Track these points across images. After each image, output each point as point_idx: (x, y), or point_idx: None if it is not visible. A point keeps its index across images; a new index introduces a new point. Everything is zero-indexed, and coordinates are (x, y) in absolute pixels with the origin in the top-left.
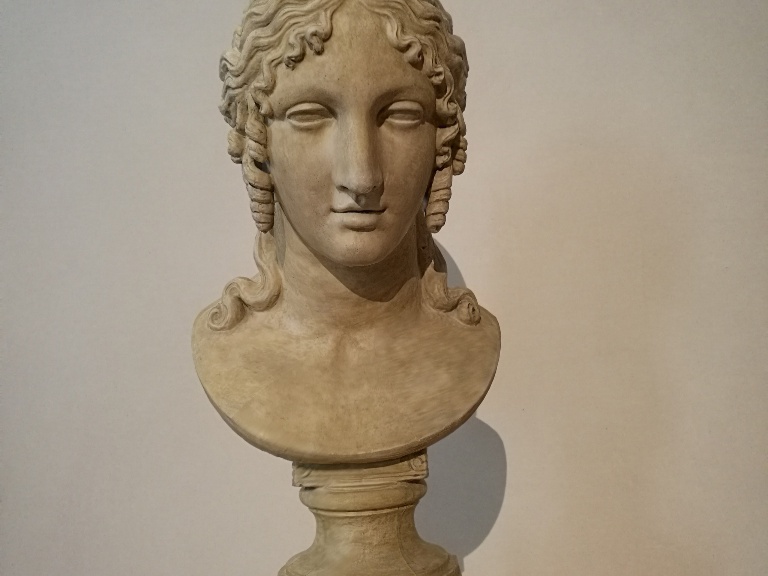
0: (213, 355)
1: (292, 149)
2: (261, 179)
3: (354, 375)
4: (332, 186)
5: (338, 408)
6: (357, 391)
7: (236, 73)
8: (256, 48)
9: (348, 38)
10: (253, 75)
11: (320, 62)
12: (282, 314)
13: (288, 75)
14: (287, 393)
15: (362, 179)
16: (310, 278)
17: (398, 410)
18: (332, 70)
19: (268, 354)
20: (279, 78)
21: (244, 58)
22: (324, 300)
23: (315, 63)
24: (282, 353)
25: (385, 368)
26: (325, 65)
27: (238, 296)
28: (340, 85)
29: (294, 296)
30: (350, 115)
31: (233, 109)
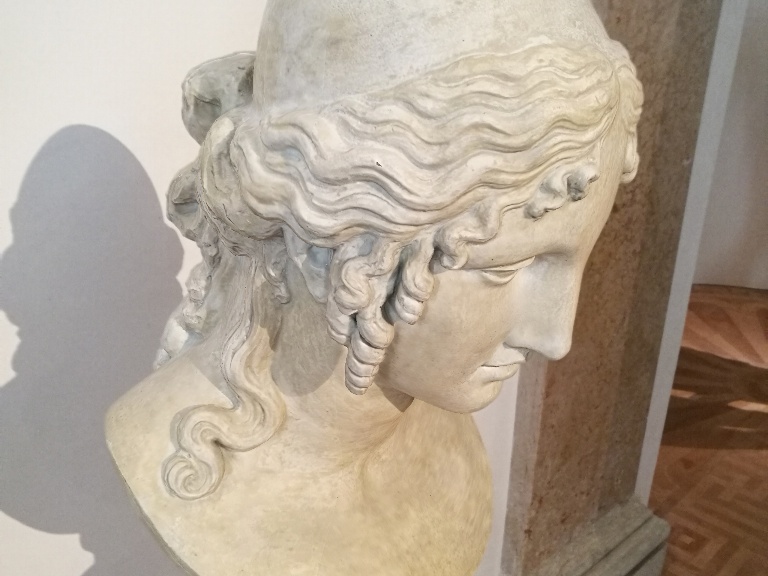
0: (213, 542)
1: (475, 309)
2: (391, 338)
3: (391, 501)
4: (500, 342)
5: (405, 556)
6: (408, 523)
7: (420, 207)
8: (484, 183)
9: (606, 174)
10: (454, 215)
11: (573, 210)
12: (283, 448)
13: (526, 227)
14: (348, 564)
15: (569, 346)
16: (361, 412)
17: (455, 529)
18: (582, 219)
19: (289, 513)
20: (506, 227)
21: (455, 194)
22: (367, 430)
23: (567, 212)
24: (305, 505)
25: (414, 477)
26: (577, 214)
27: (213, 439)
28: (582, 237)
29: (315, 428)
30: (575, 270)
31: (350, 234)
